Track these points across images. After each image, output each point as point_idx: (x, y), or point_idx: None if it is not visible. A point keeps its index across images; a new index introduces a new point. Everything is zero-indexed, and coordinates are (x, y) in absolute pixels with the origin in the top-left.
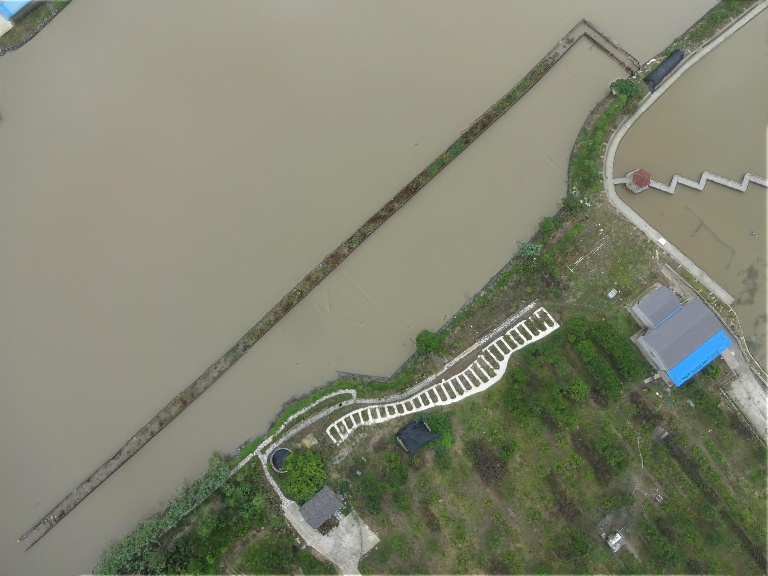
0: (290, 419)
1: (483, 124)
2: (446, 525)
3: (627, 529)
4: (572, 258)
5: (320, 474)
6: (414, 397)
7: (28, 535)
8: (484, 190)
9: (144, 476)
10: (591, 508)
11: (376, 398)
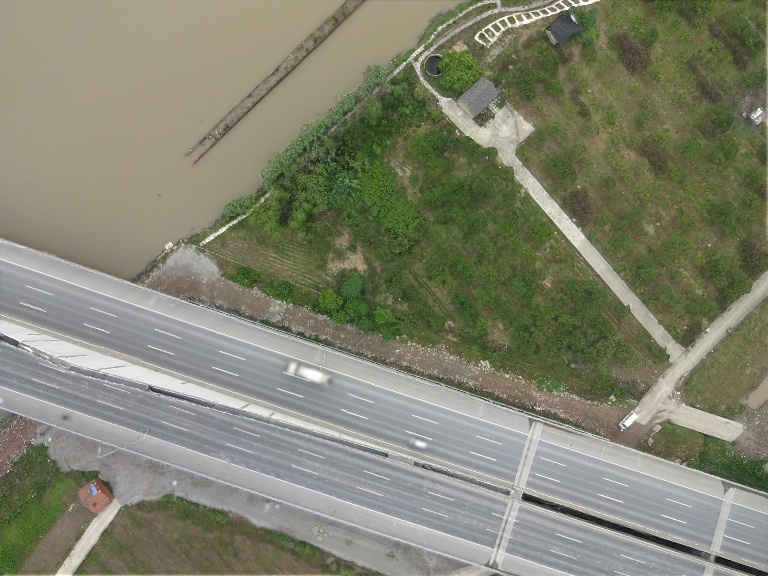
0: (439, 29)
1: None
2: (596, 112)
3: (766, 108)
4: None
5: (476, 66)
6: (556, 3)
7: (194, 150)
8: None
9: (301, 93)
10: (731, 91)
11: (520, 6)
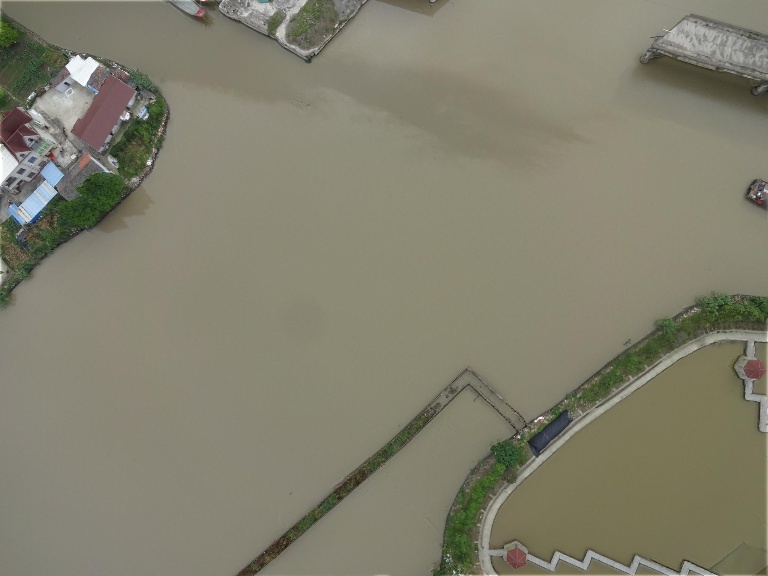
0: None
1: (357, 481)
2: None
3: None
4: None
5: None
6: None
7: None
8: (358, 545)
9: None
10: None
11: None
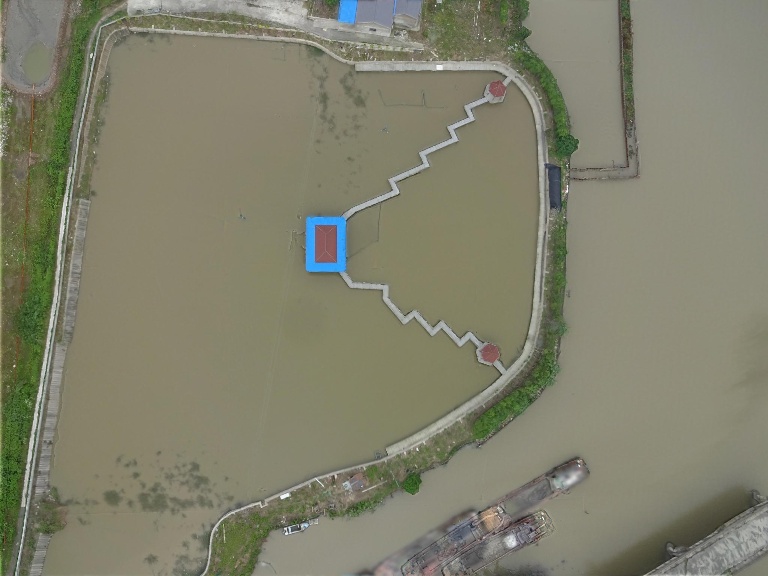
0: None
1: (627, 39)
2: None
3: None
4: (485, 3)
5: None
6: None
7: None
8: (579, 4)
9: None
10: None
11: None
